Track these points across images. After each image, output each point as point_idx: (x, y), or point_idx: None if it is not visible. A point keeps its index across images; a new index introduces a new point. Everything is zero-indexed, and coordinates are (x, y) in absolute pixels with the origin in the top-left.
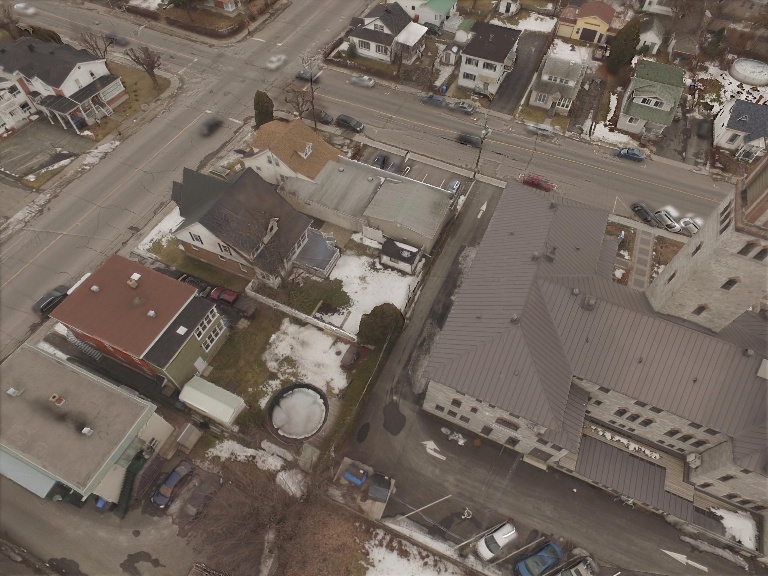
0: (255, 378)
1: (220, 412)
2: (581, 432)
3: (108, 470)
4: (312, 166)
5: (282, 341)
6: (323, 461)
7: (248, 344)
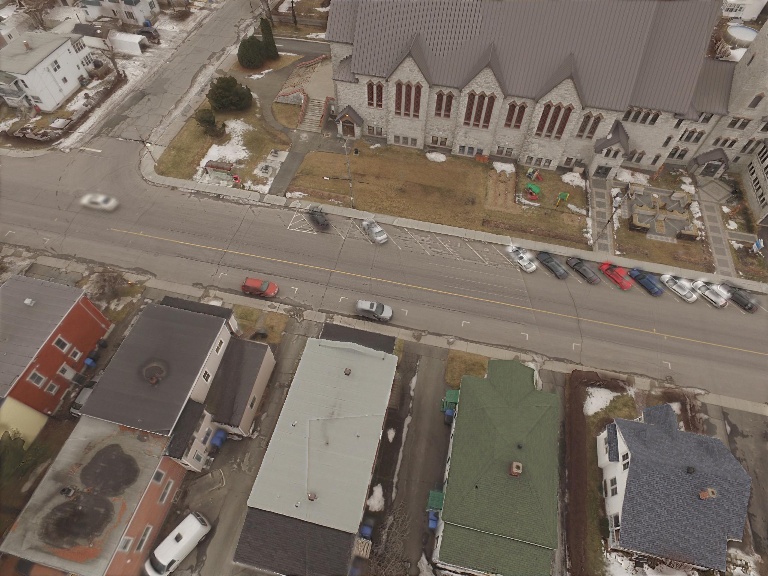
0: None
1: None
2: None
3: None
4: None
5: None
6: None
7: None
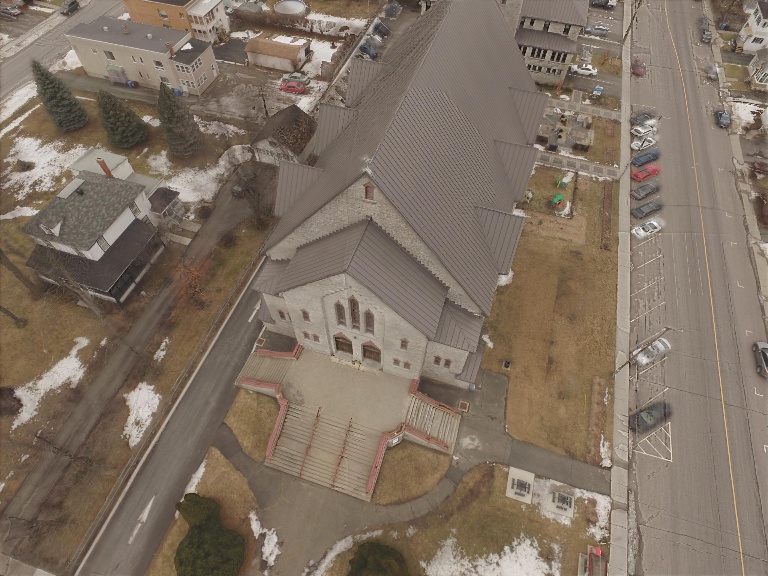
0: None
1: None
2: None
3: None
4: None
5: None
6: None
7: None
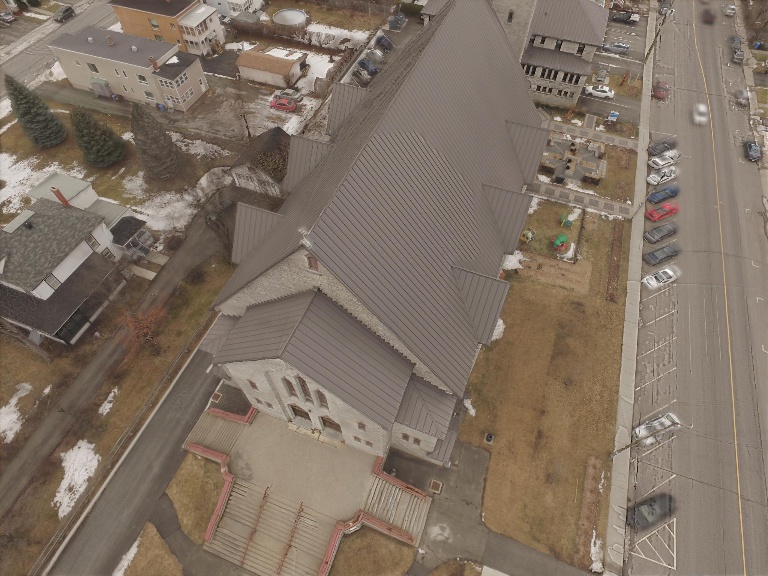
0: None
1: None
2: None
3: None
4: None
5: None
6: (403, 3)
7: None
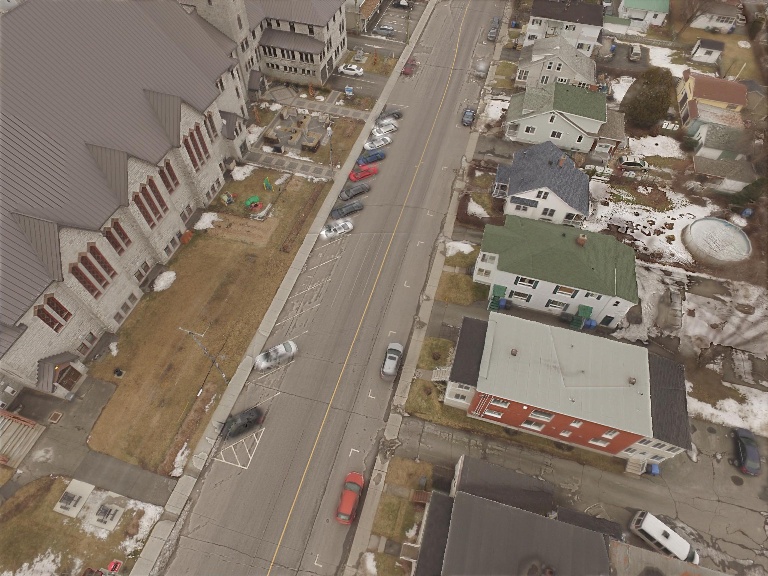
0: None
1: None
2: None
3: None
4: None
5: None
6: None
7: None
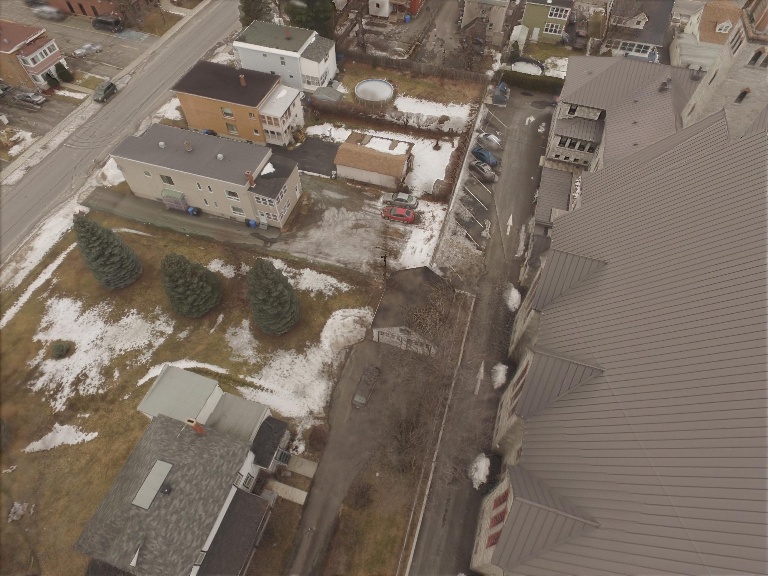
0: (538, 56)
1: (514, 37)
2: (570, 136)
3: (476, 2)
4: (712, 37)
5: (566, 61)
6: (505, 71)
7: (557, 51)
